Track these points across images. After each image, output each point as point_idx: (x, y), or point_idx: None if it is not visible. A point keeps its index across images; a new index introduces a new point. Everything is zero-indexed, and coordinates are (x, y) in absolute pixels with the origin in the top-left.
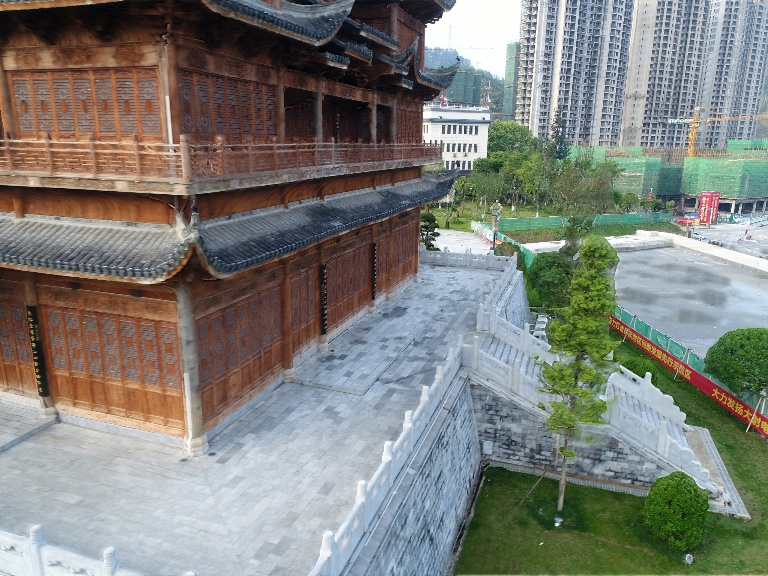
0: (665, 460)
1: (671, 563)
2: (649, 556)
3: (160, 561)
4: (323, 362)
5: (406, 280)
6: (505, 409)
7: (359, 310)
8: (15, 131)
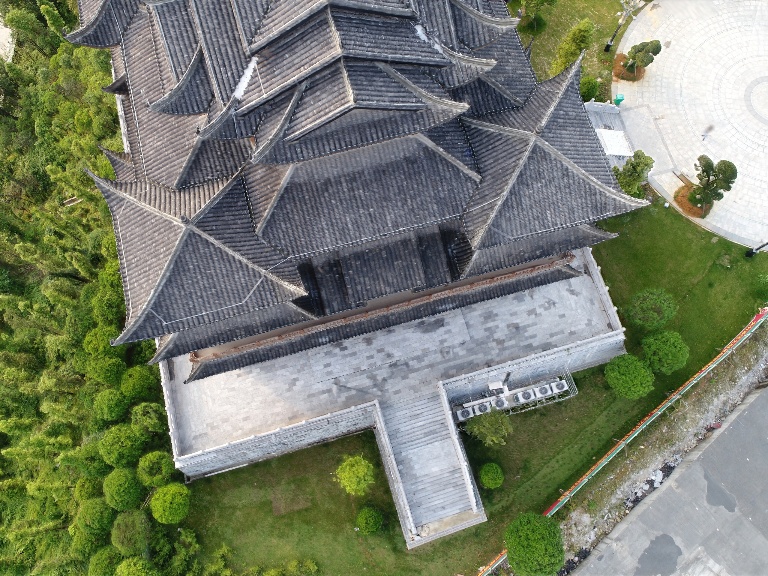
0: (406, 510)
1: (353, 523)
2: (352, 514)
3: (191, 403)
4: (331, 346)
5: None
6: None
7: None
8: None
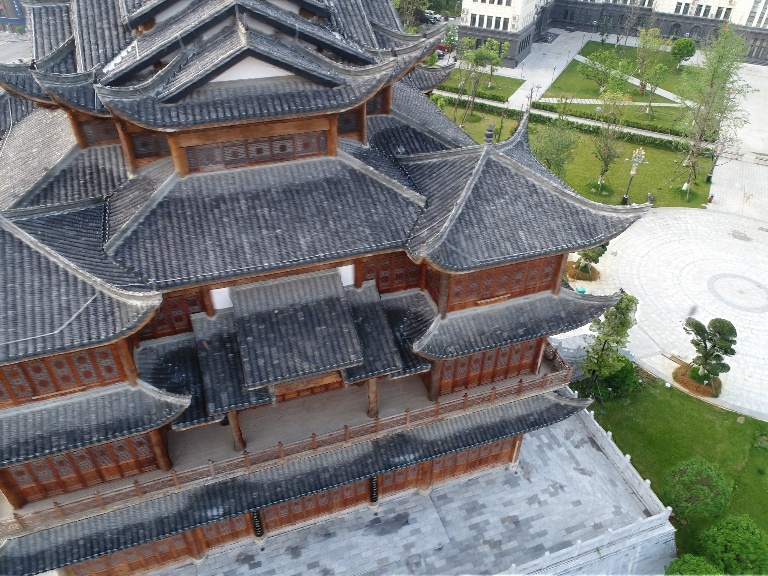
0: None
1: None
2: None
3: None
4: (236, 561)
5: (480, 470)
6: None
7: (345, 508)
8: None
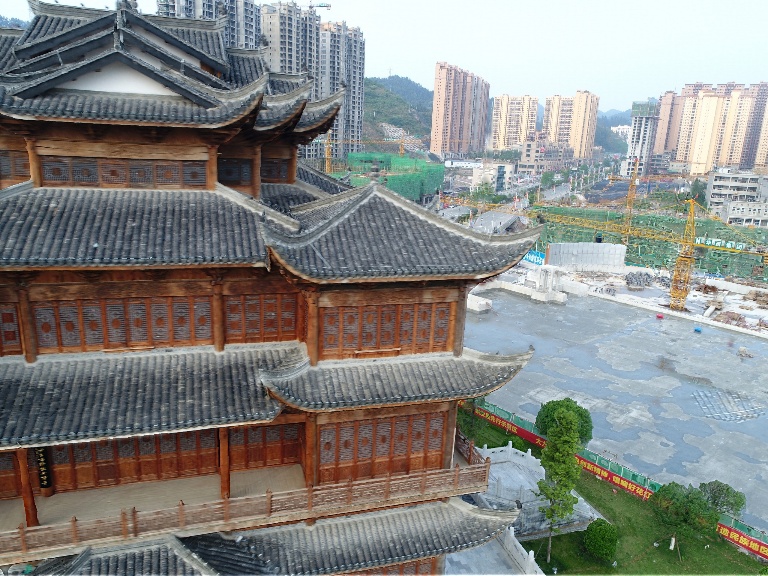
0: None
1: (609, 570)
2: (599, 570)
3: None
4: None
5: None
6: None
7: None
8: (317, 464)
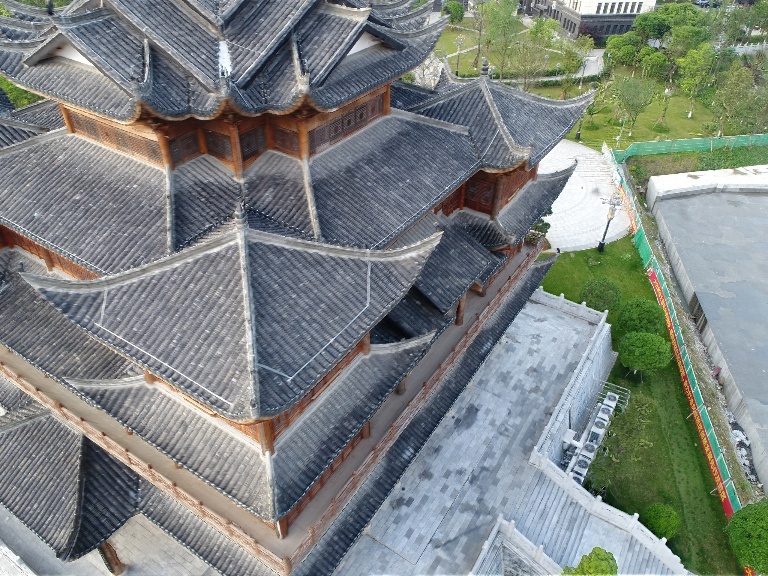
0: None
1: None
2: None
3: None
4: (393, 509)
5: None
6: (526, 568)
7: None
8: None
